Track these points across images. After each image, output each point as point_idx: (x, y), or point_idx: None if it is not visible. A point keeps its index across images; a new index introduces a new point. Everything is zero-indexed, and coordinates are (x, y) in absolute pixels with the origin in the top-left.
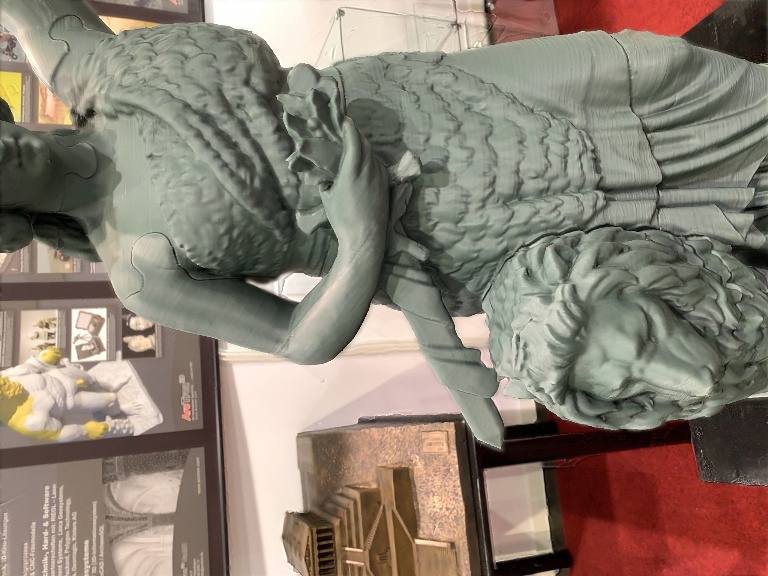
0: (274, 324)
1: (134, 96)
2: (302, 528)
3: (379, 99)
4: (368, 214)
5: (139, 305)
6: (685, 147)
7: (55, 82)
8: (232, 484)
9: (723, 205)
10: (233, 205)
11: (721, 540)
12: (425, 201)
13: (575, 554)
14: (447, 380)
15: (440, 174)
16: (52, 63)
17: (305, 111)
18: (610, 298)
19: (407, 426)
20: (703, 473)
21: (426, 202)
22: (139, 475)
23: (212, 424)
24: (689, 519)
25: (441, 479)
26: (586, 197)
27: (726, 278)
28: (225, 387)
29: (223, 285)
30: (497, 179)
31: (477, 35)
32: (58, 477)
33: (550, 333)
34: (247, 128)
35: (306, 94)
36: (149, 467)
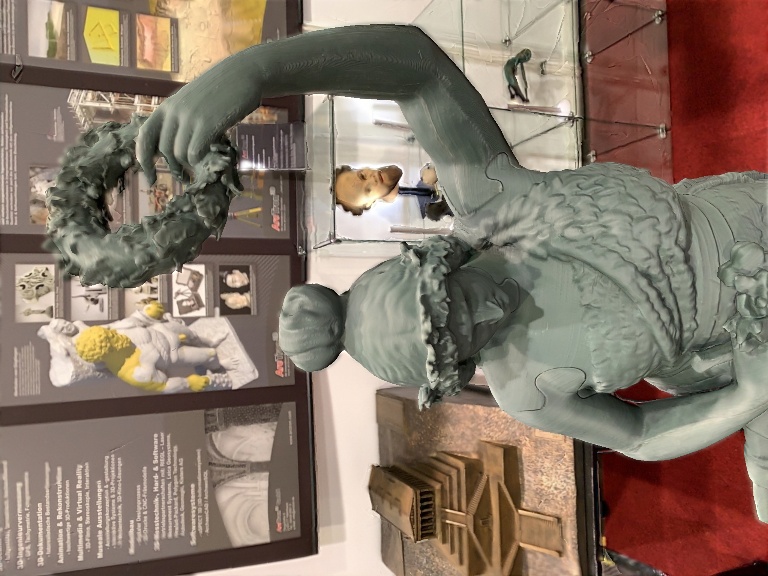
0: (632, 432)
1: (584, 253)
2: (401, 487)
3: (766, 249)
4: None
5: (532, 418)
6: None
7: (476, 213)
8: (316, 434)
9: None
10: (656, 354)
11: None
12: None
13: (614, 507)
14: (761, 481)
15: None
16: (482, 199)
17: (753, 289)
18: None
19: None
20: None
21: None
22: (237, 426)
23: (302, 380)
24: (742, 495)
25: (553, 462)
26: None
27: None
28: None
29: (599, 401)
30: None
31: (587, 5)
32: (165, 426)
33: None
34: (670, 282)
35: (751, 271)
36: (246, 419)
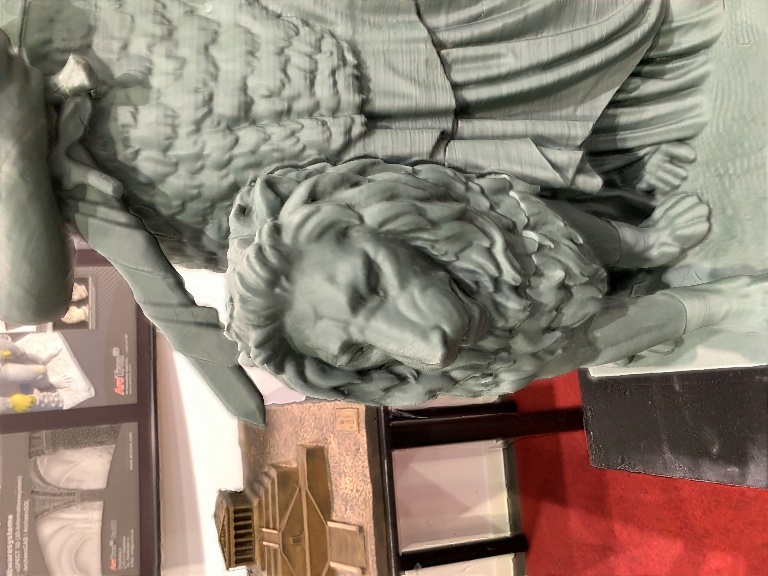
0: None
1: None
2: (223, 507)
3: None
4: (1, 131)
5: None
6: (494, 68)
7: None
8: (170, 460)
9: (548, 141)
10: None
11: (664, 528)
12: (118, 122)
13: (530, 538)
14: (176, 344)
15: (137, 89)
16: None
17: None
18: (325, 241)
19: (323, 403)
20: (592, 458)
21: (119, 124)
22: (68, 450)
23: (147, 399)
24: (634, 505)
25: (352, 459)
26: (336, 121)
27: (522, 224)
28: (163, 361)
29: None
30: (215, 97)
31: None
32: None
33: (239, 283)
34: None
35: None
36: (79, 442)
